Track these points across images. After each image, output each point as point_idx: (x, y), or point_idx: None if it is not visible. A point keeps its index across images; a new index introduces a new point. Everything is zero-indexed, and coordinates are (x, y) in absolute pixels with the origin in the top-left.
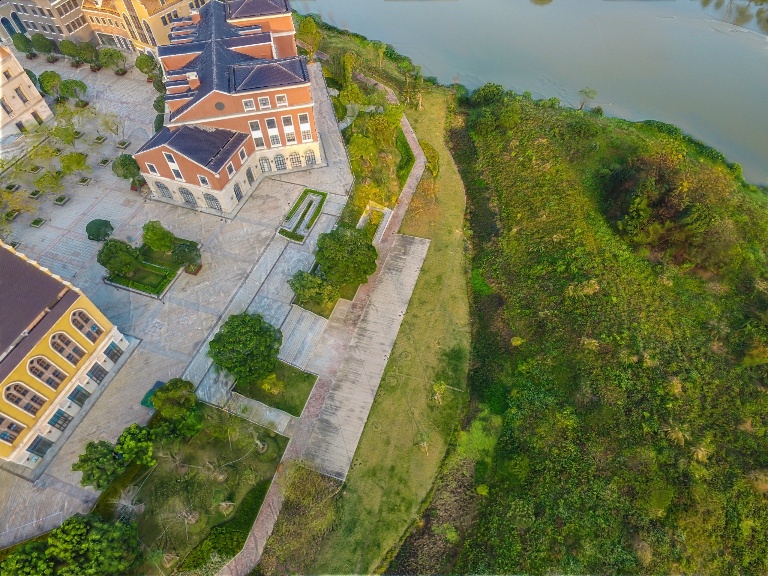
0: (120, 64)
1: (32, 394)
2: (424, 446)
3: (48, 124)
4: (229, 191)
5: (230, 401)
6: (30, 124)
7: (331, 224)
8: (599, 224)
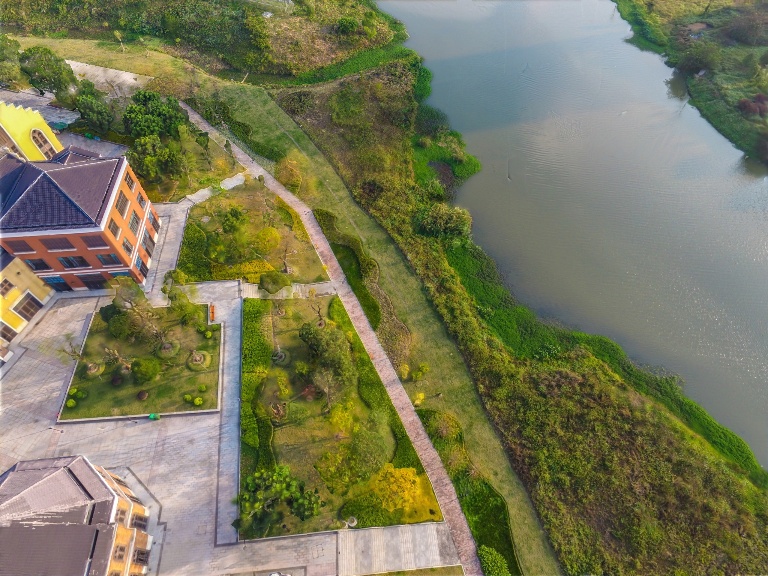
0: None
1: None
2: (149, 55)
3: None
4: None
5: None
6: None
7: None
8: None
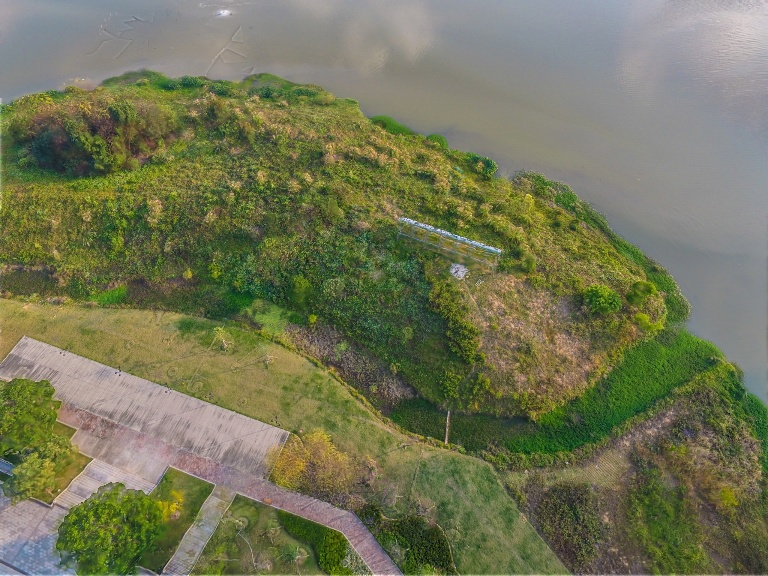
0: None
1: None
2: (269, 360)
3: None
4: None
5: (174, 574)
6: None
7: None
8: (87, 183)
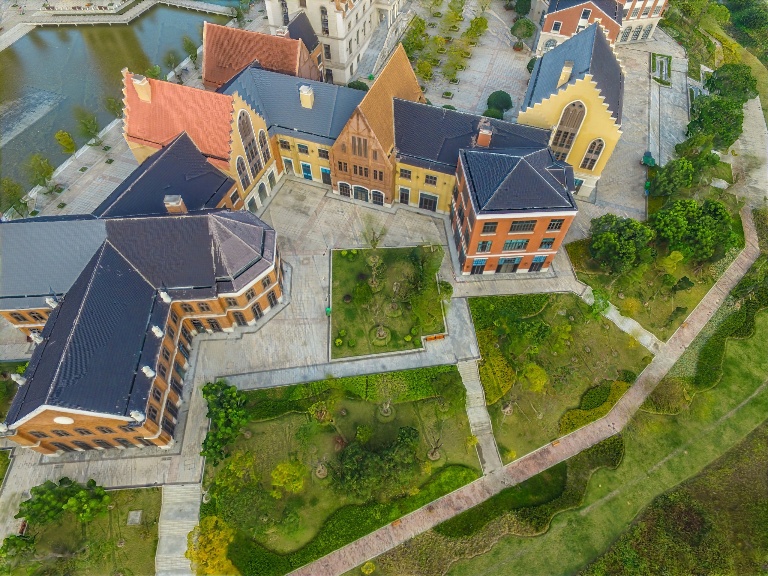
0: None
1: None
2: None
3: (406, 7)
4: None
5: None
6: (400, 5)
7: (683, 77)
8: None
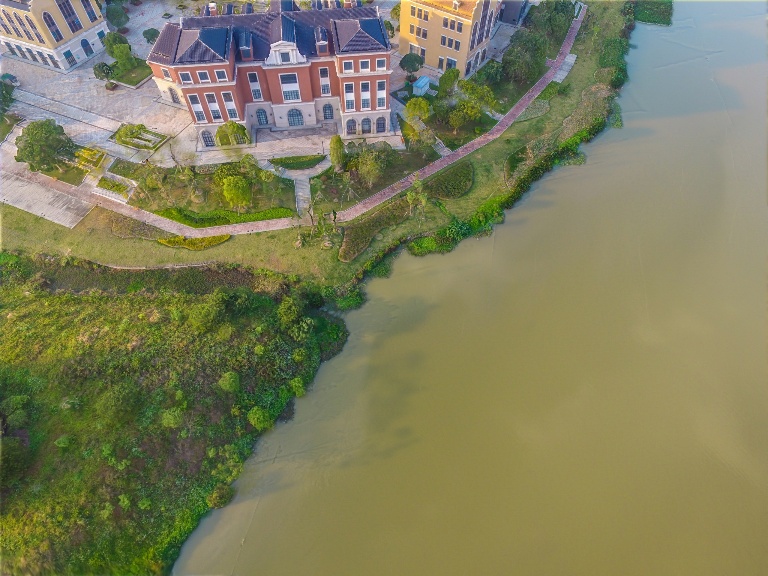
0: (397, 21)
1: (6, 24)
2: None
3: None
4: (163, 85)
5: None
6: None
7: (121, 156)
8: None
